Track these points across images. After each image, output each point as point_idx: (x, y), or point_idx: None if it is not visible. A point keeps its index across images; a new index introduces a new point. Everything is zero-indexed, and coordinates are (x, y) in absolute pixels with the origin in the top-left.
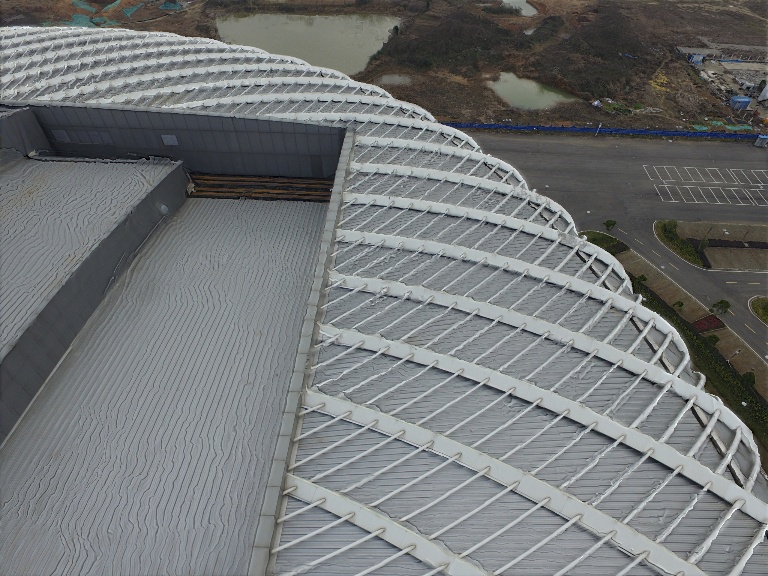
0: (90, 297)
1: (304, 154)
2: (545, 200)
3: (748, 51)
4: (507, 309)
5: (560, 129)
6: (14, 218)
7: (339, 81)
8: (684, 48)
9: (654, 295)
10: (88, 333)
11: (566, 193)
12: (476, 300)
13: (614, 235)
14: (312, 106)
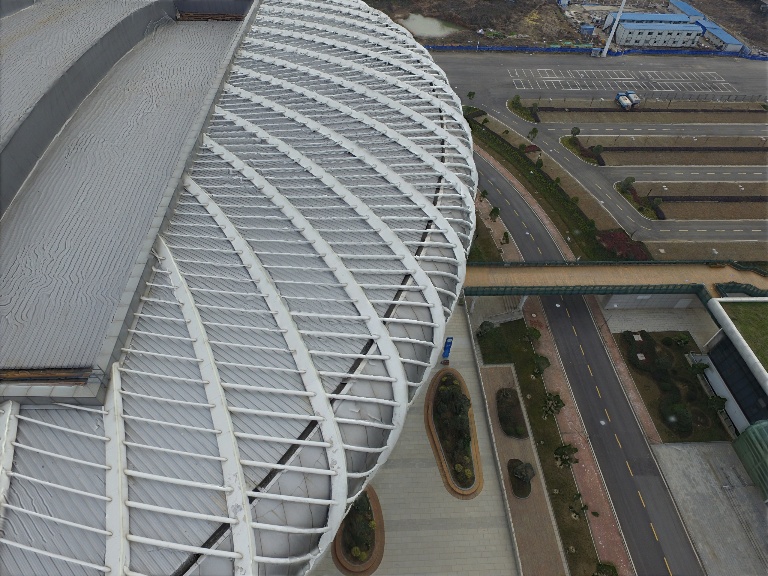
0: (138, 33)
1: None
2: (378, 12)
3: None
4: (339, 28)
5: (450, 48)
6: None
7: None
8: None
9: (497, 135)
10: (139, 48)
11: None
12: None
13: (478, 107)
14: None
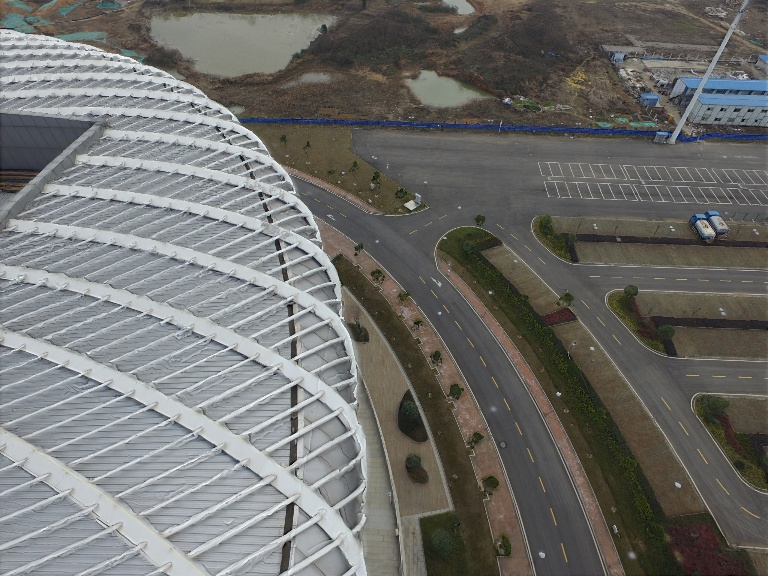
0: None
1: None
2: (279, 192)
3: (672, 49)
4: (137, 295)
5: (464, 126)
6: None
7: (141, 77)
8: (609, 46)
9: (513, 289)
10: None
11: (454, 189)
12: (116, 287)
13: (491, 230)
14: (85, 101)
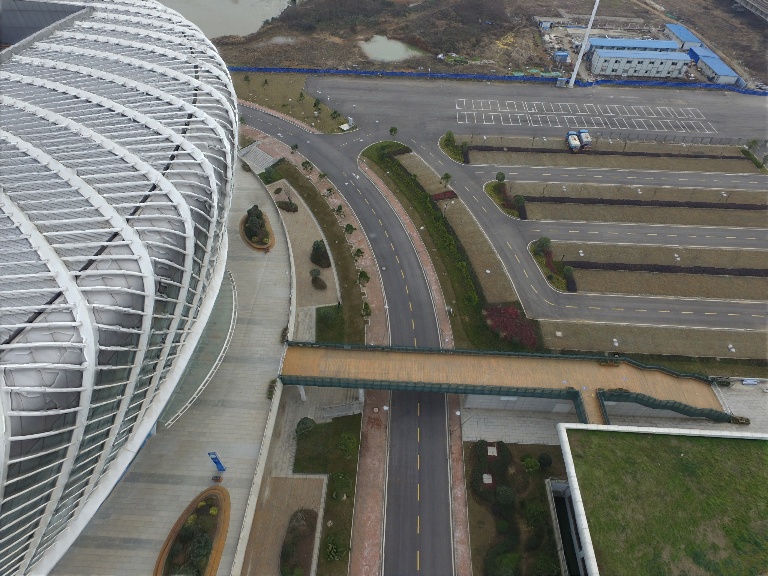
0: None
1: None
2: (203, 48)
3: (595, 20)
4: (106, 72)
5: (400, 74)
6: None
7: None
8: (540, 17)
9: (412, 178)
10: None
11: (383, 117)
12: None
13: (406, 143)
14: (81, 0)
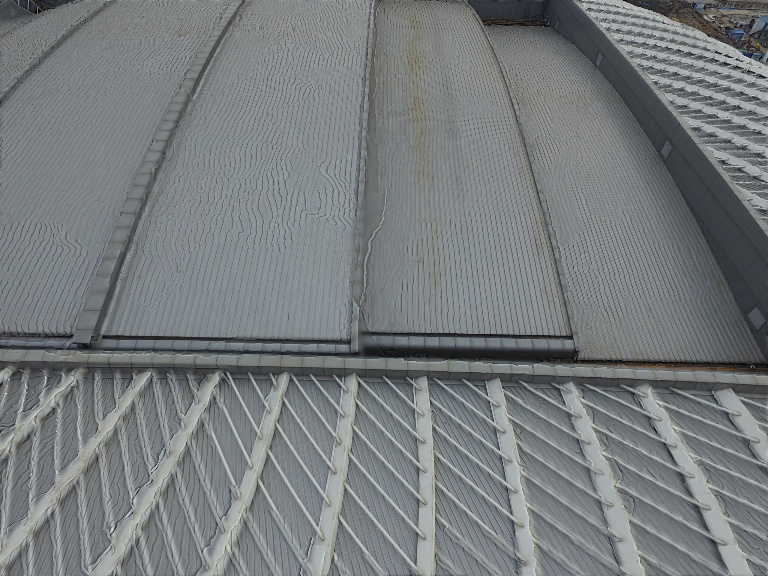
0: None
1: (523, 2)
2: None
3: (739, 2)
4: None
5: None
6: (426, 6)
7: None
8: None
9: None
10: None
11: None
12: None
13: None
14: None
